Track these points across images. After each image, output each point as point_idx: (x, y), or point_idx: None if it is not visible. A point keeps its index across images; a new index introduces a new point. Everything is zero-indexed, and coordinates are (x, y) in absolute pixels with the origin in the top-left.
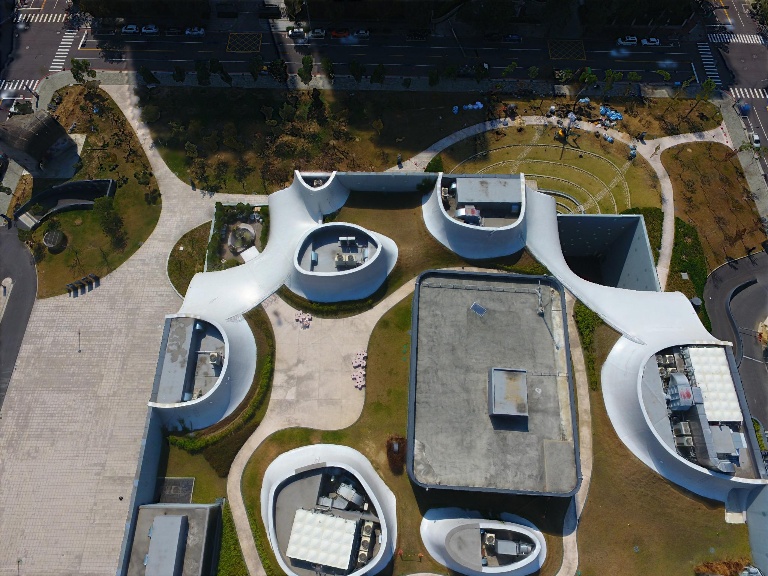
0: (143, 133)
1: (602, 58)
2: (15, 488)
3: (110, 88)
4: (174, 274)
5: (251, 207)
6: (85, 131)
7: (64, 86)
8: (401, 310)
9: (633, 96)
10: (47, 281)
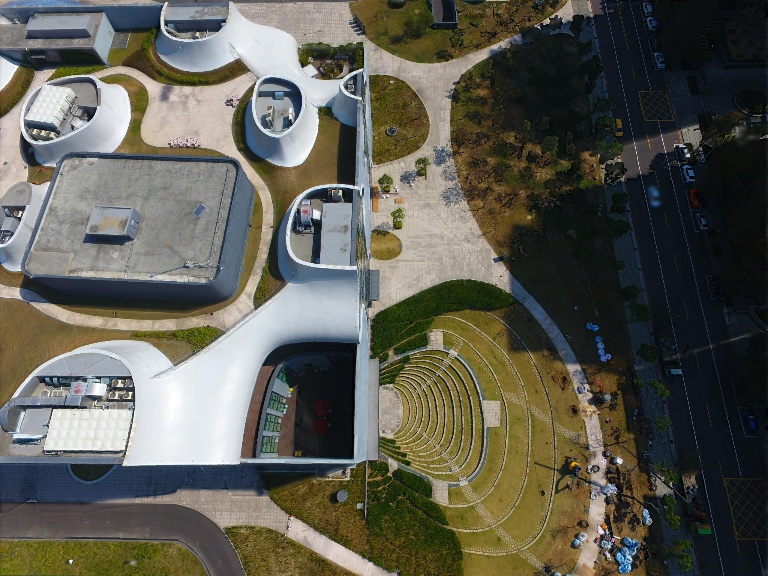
0: (517, 40)
1: (749, 570)
2: None
3: (568, 8)
4: None
5: None
6: None
7: None
8: None
9: None
10: (364, 5)
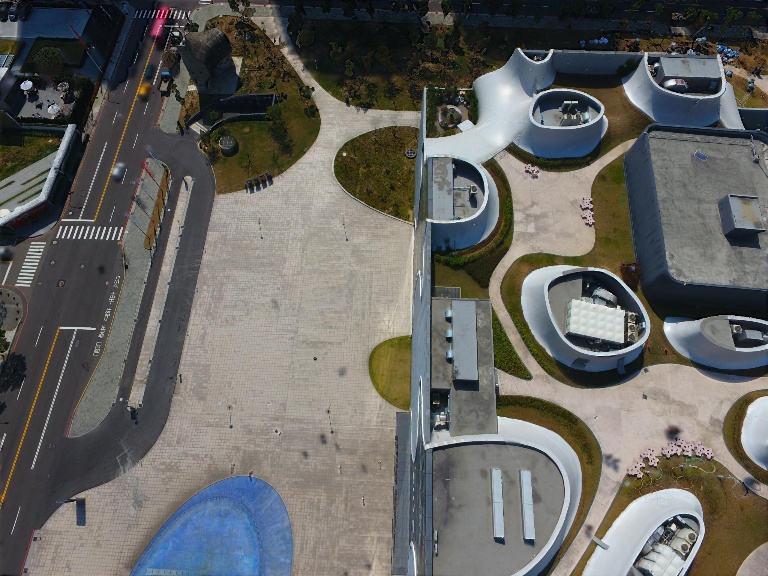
0: (293, 58)
1: (713, 4)
2: (218, 348)
3: (257, 19)
4: (341, 175)
5: (456, 91)
6: (241, 54)
7: (215, 17)
8: (614, 168)
9: (746, 37)
10: (224, 179)
